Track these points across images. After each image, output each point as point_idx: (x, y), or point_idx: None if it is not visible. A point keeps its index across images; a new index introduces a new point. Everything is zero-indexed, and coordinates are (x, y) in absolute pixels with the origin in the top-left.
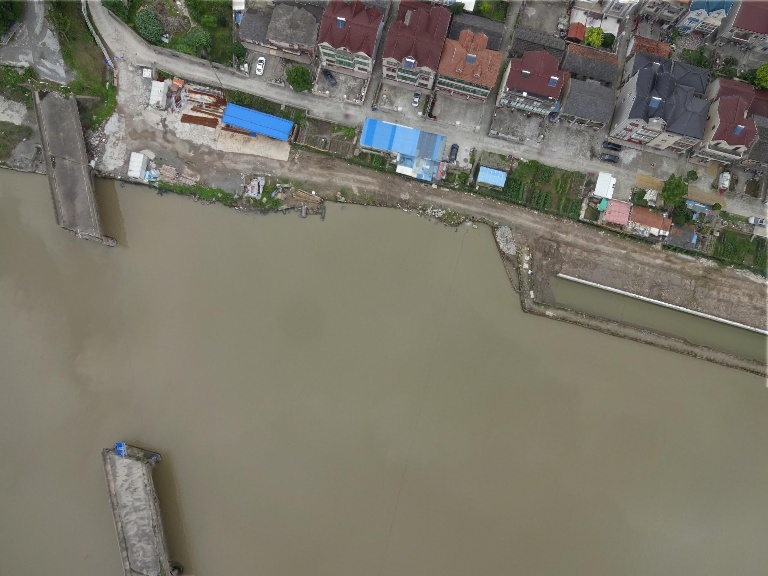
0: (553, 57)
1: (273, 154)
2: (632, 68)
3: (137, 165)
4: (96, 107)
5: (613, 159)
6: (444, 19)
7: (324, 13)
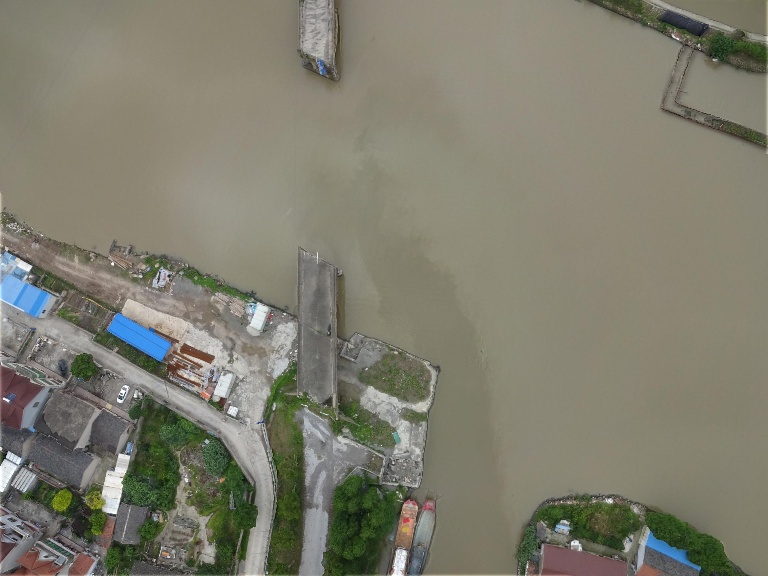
0: None
1: (139, 308)
2: None
3: (258, 316)
4: (292, 389)
5: None
6: None
7: (23, 412)
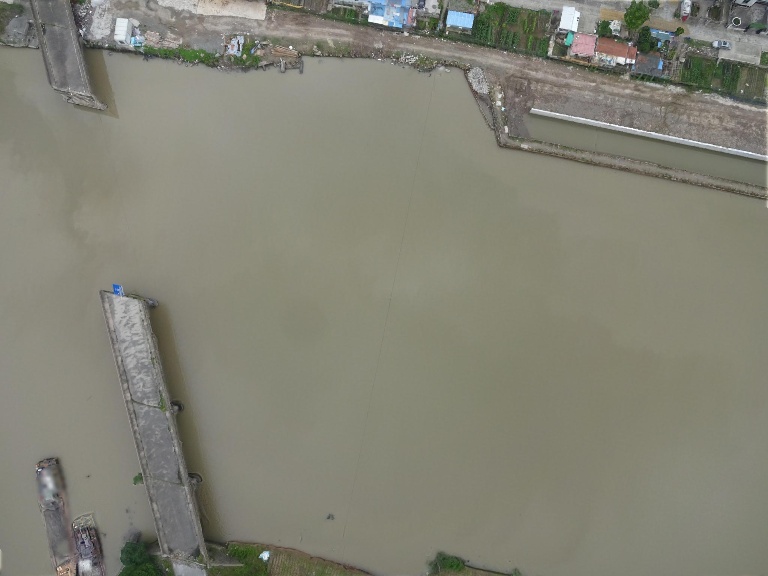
0: None
1: (250, 14)
2: None
3: (122, 29)
4: None
5: None
6: None
7: None
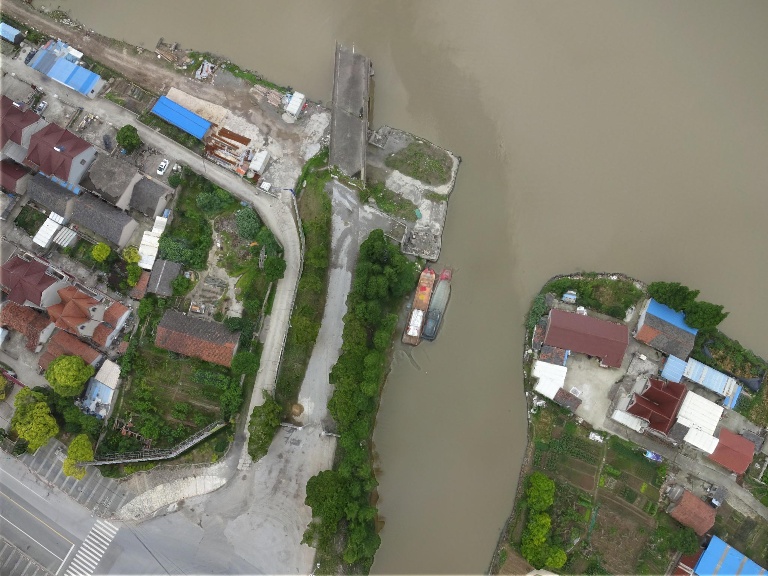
0: None
1: (181, 95)
2: None
3: (294, 102)
4: None
5: None
6: None
7: (72, 162)
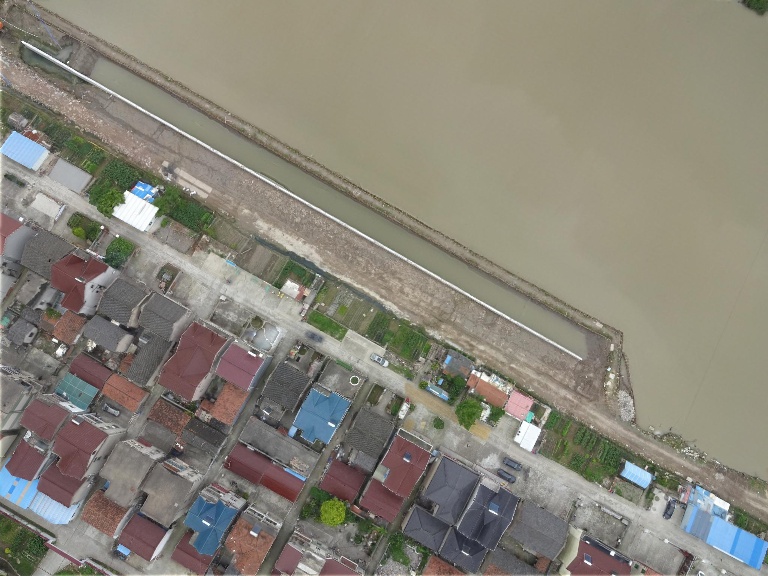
0: None
1: None
2: None
3: None
4: None
5: (510, 462)
6: None
7: None
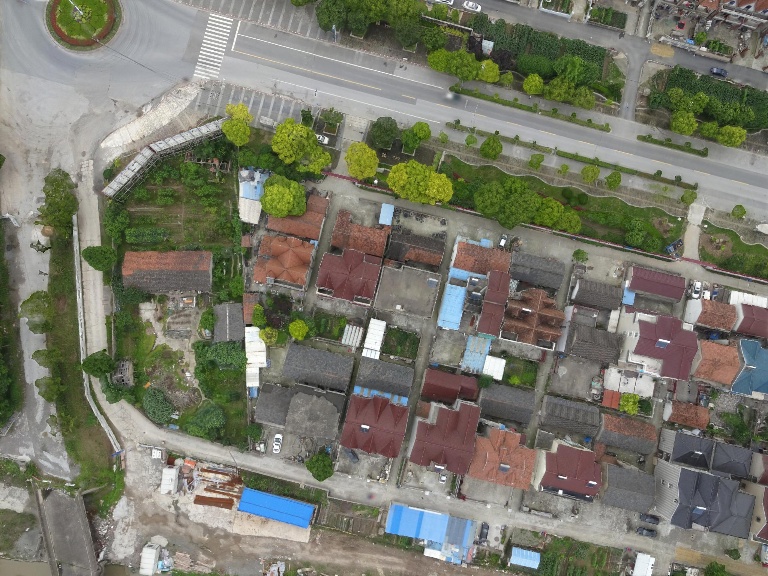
0: (590, 452)
1: (293, 536)
2: (672, 452)
3: (149, 562)
4: (103, 490)
5: (651, 535)
6: (474, 417)
7: (346, 418)
